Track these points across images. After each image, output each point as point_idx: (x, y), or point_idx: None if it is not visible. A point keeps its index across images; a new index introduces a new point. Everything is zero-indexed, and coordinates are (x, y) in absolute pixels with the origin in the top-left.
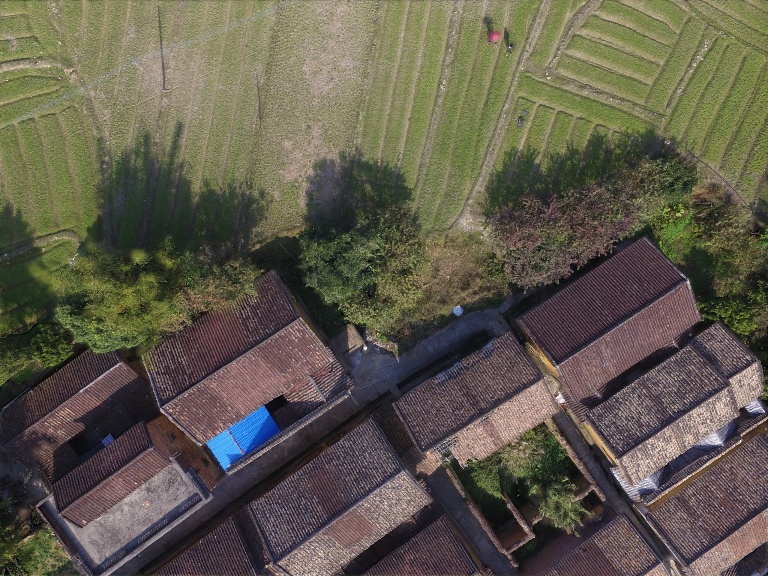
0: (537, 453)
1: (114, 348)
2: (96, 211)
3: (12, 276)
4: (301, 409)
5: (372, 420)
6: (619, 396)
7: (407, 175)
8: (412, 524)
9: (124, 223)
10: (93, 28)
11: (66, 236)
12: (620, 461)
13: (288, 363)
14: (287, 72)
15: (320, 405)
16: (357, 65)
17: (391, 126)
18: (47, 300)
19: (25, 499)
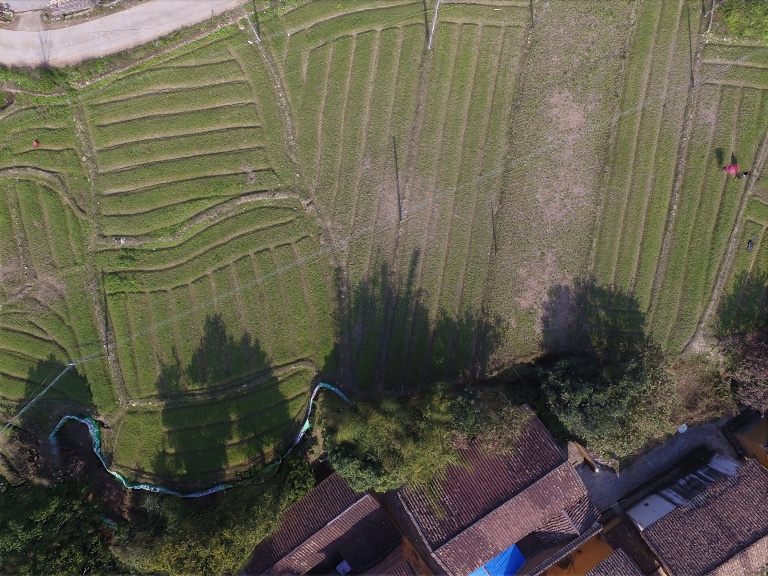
0: None
1: (371, 486)
2: (332, 340)
3: (250, 406)
4: (548, 539)
5: (622, 550)
6: None
7: (640, 300)
8: None
9: (363, 353)
10: (330, 160)
11: (304, 366)
12: None
13: (549, 500)
14: (521, 200)
15: (574, 538)
16: (589, 192)
17: (624, 252)
18: (284, 429)
19: None
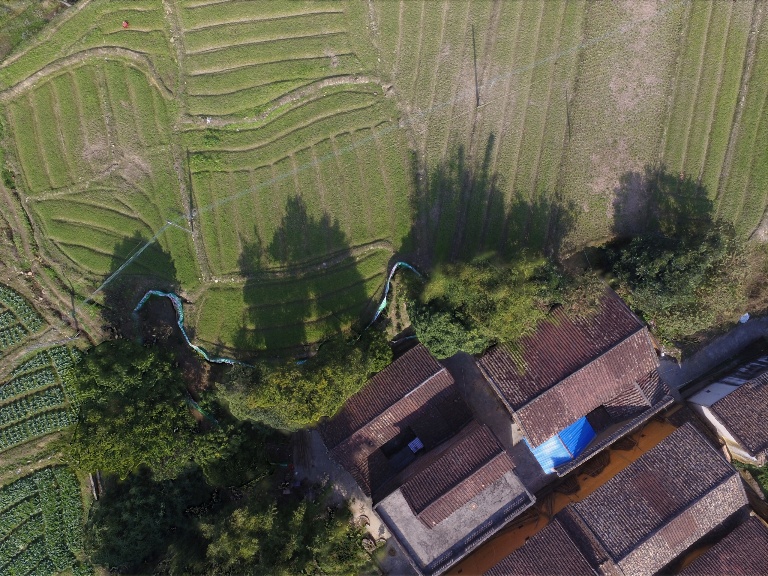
0: None
1: (451, 354)
2: (410, 222)
3: (329, 284)
4: (619, 413)
5: (691, 424)
6: None
7: (709, 188)
8: (717, 525)
9: (440, 233)
10: (410, 46)
11: (382, 246)
12: None
13: (624, 369)
14: (594, 89)
15: (646, 410)
16: (661, 82)
17: (693, 141)
18: (361, 308)
19: (324, 502)
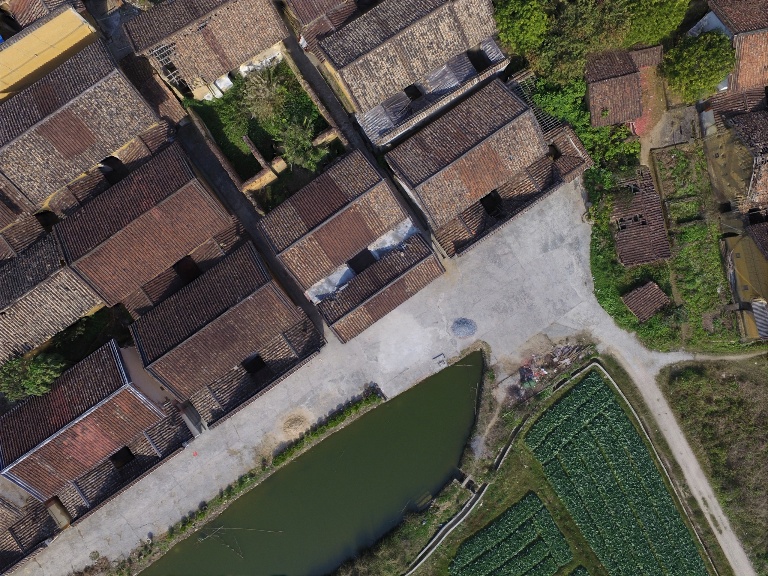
0: (287, 106)
1: None
2: None
3: None
4: None
5: (100, 38)
6: (351, 25)
7: None
8: (149, 158)
9: None
10: None
11: None
12: (340, 74)
13: None
14: None
15: None
16: None
17: None
18: None
19: None
